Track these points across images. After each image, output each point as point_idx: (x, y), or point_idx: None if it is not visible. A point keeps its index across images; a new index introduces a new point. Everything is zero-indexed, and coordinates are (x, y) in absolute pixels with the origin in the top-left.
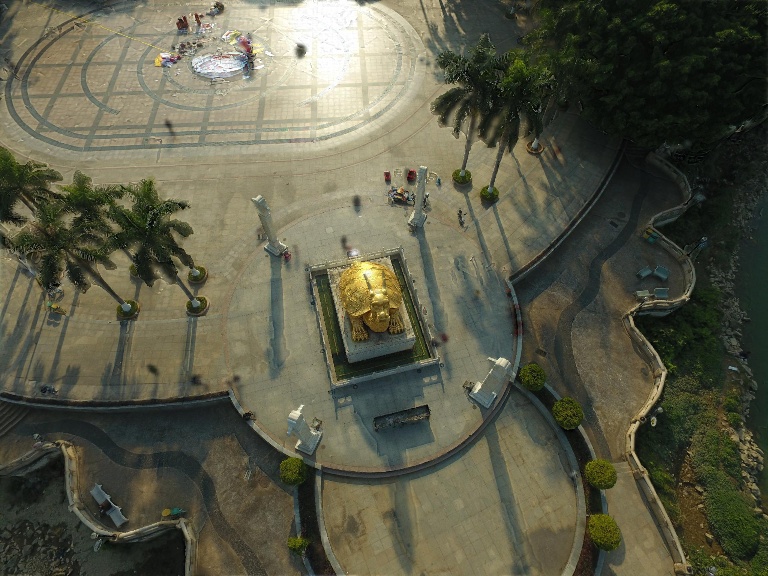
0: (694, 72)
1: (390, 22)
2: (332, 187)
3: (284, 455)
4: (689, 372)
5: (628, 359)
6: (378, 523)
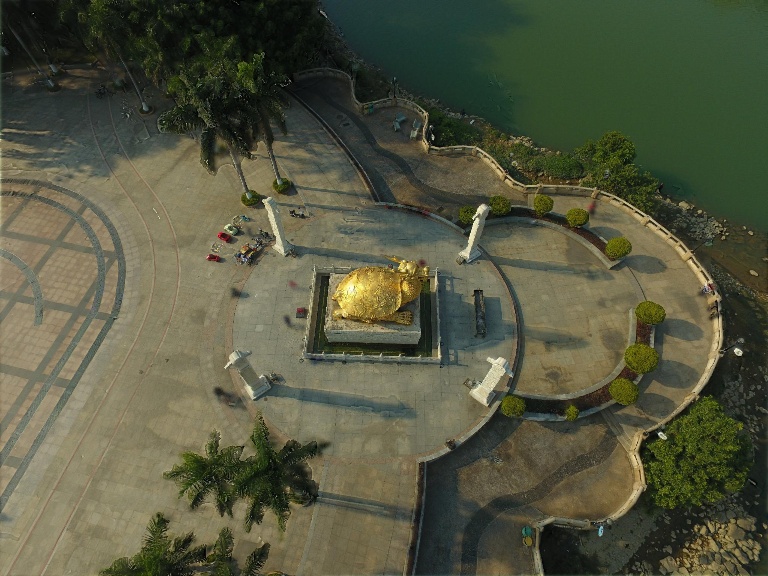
0: None
1: None
2: (199, 314)
3: None
4: (469, 143)
5: (459, 164)
6: (553, 356)
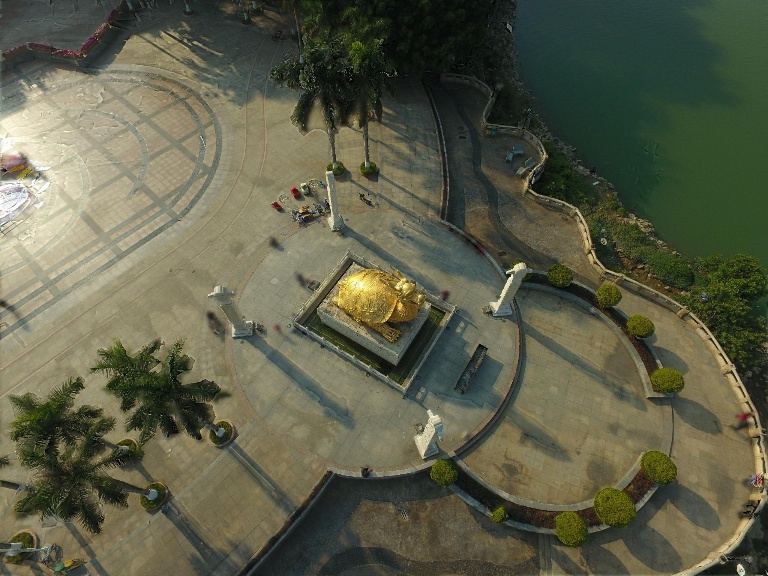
0: None
1: (142, 76)
2: (238, 246)
3: (416, 474)
4: (579, 203)
5: (550, 218)
6: (523, 451)
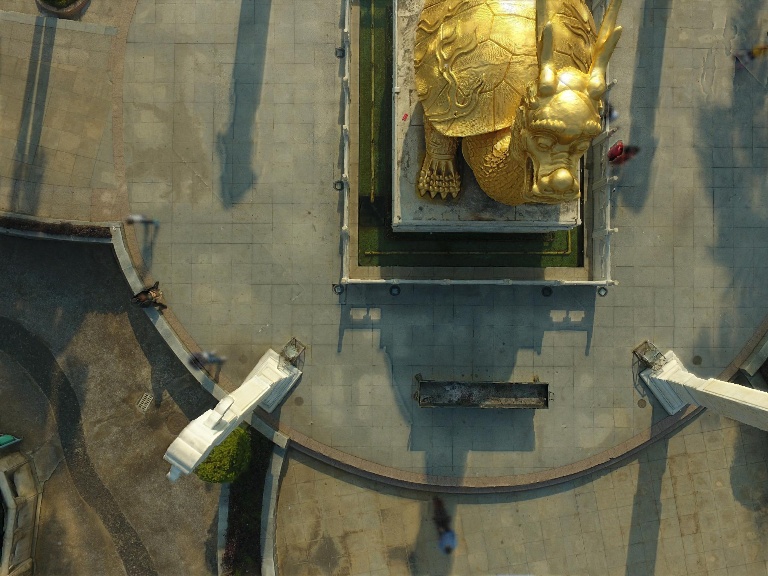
0: None
1: None
2: None
3: None
4: None
5: None
6: (376, 563)
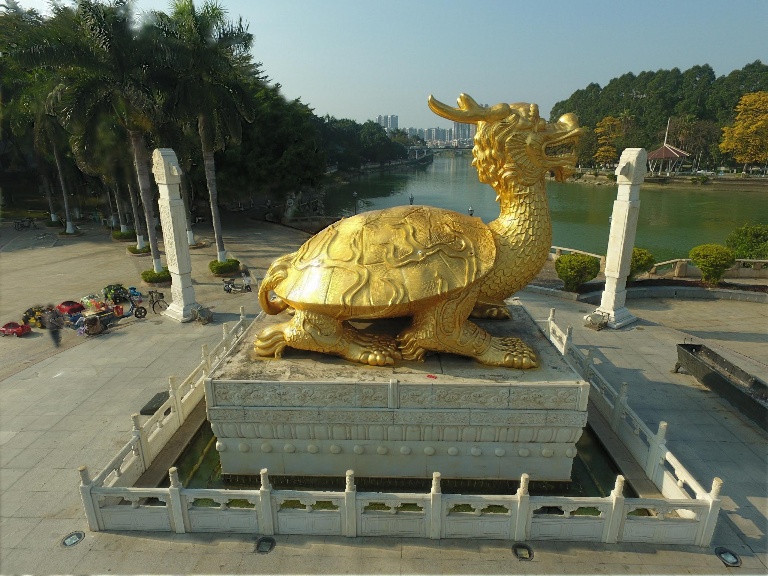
0: (269, 120)
1: None
2: None
3: None
4: None
5: None
6: None
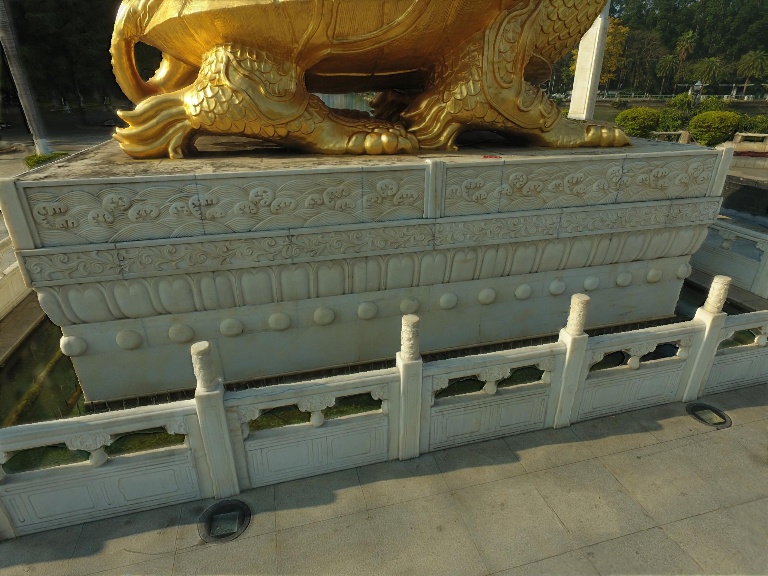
0: None
1: None
2: None
3: None
4: None
5: None
6: None
